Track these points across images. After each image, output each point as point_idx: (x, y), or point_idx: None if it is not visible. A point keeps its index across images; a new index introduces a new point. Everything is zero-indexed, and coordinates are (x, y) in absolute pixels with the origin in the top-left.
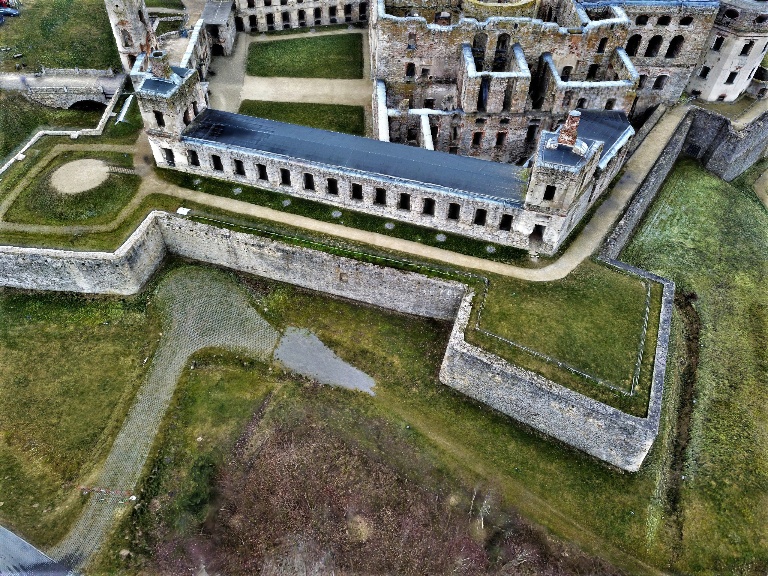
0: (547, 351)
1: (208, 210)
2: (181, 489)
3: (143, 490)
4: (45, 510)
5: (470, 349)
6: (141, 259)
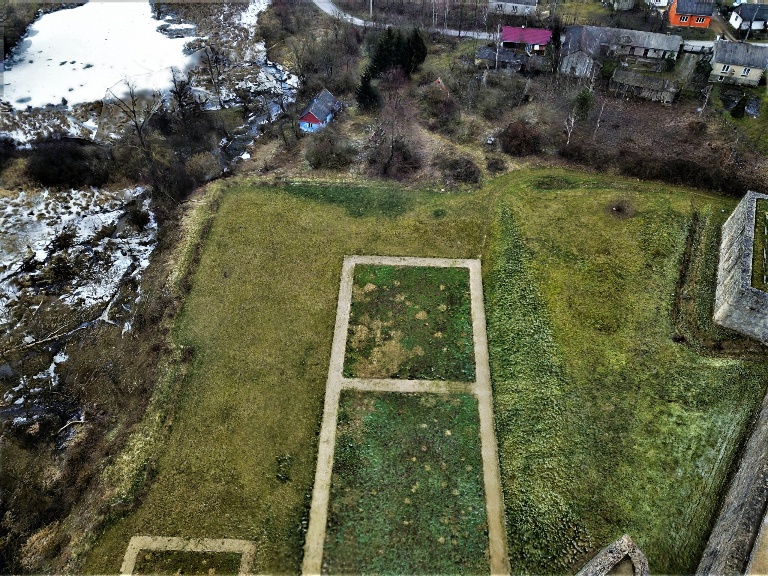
0: None
1: None
2: None
3: None
4: None
5: None
6: None
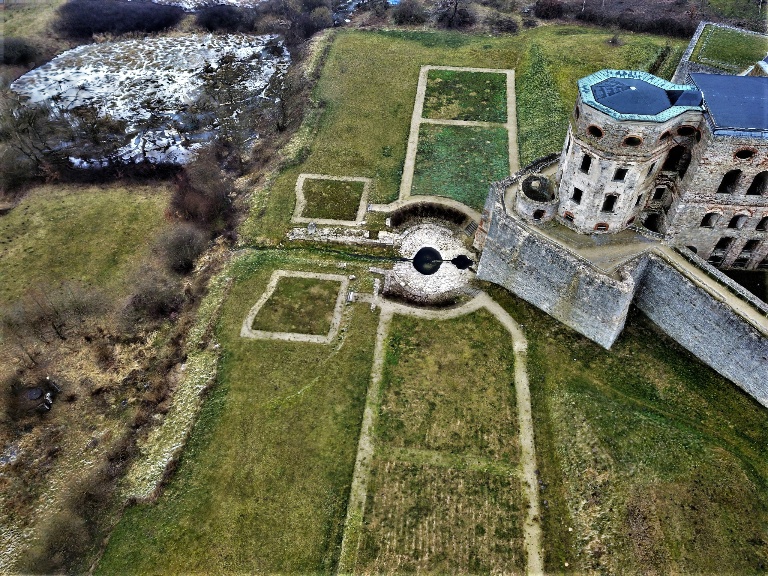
0: (761, 40)
1: None
2: None
3: None
4: None
5: None
6: None
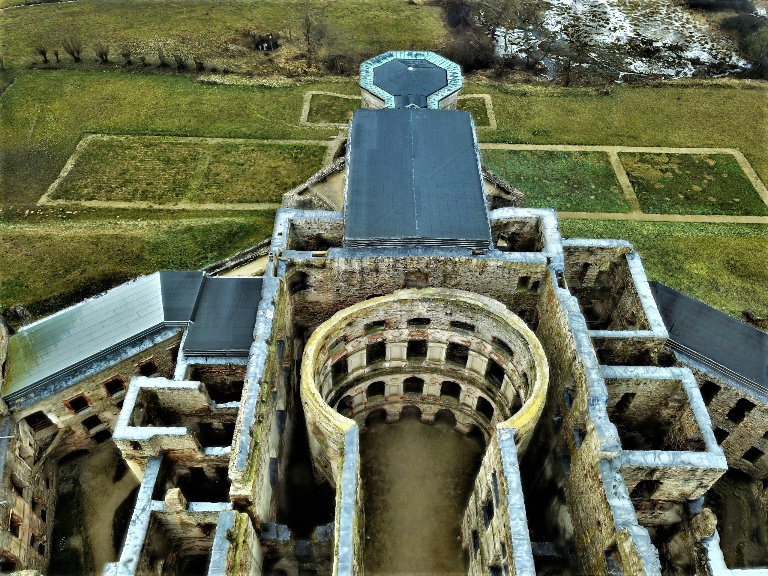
0: None
1: None
2: None
3: None
4: None
5: None
6: None
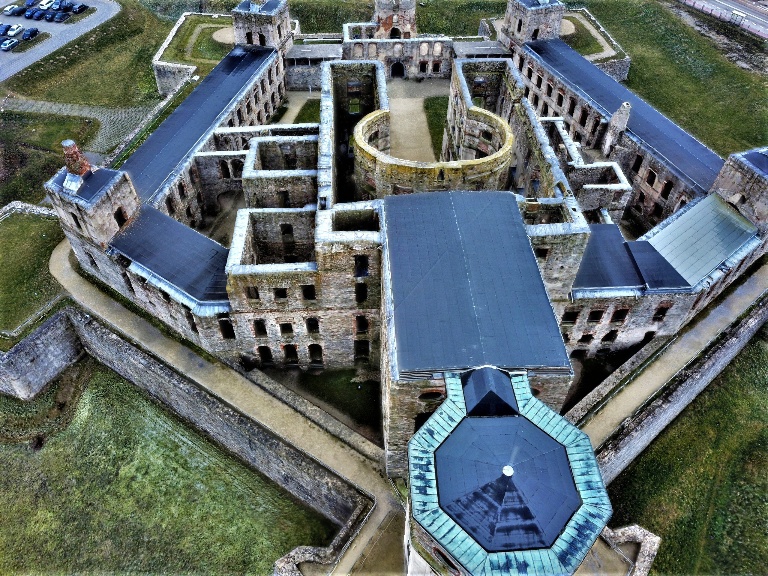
0: None
1: (195, 87)
2: (6, 129)
3: (6, 113)
4: (10, 88)
5: (3, 209)
6: (169, 80)
